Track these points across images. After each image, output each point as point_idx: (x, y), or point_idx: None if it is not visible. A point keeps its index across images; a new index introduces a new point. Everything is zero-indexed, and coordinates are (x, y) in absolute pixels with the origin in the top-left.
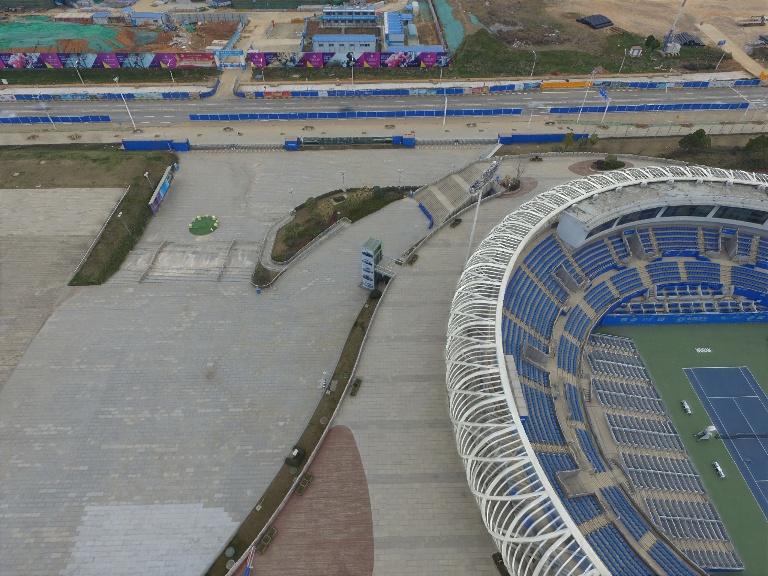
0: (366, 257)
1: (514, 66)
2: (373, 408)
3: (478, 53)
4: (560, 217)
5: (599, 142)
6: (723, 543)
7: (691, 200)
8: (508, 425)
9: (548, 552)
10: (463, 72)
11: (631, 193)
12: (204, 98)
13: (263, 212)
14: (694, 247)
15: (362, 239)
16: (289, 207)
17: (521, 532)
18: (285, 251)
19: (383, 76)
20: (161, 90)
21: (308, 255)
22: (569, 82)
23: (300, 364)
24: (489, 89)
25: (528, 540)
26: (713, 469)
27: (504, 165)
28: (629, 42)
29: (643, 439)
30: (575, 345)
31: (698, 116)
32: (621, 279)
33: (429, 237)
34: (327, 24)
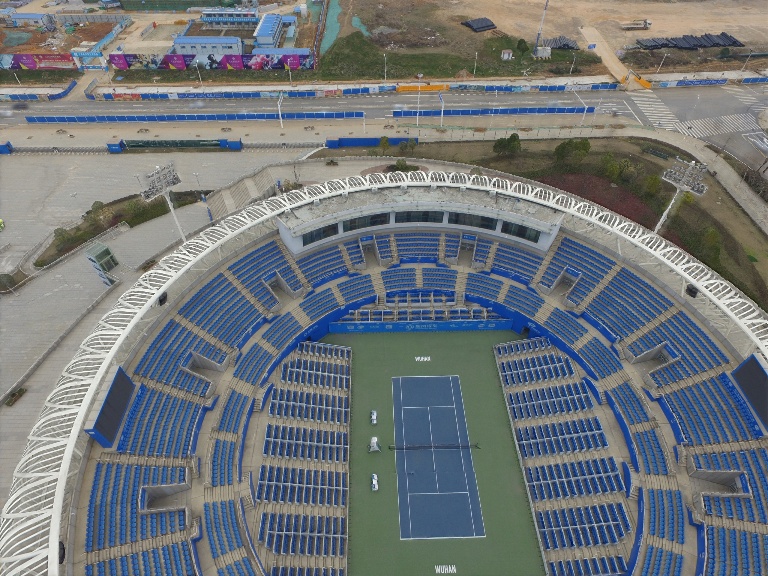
0: (93, 263)
1: (379, 69)
2: (23, 419)
3: (346, 56)
4: (276, 223)
5: (427, 146)
6: (341, 559)
7: (418, 206)
8: (62, 439)
9: (11, 574)
10: (326, 75)
11: (359, 198)
12: (54, 100)
13: (55, 216)
14: (434, 253)
15: (133, 244)
16: (84, 211)
17: (3, 552)
18: (52, 256)
19: (244, 78)
20: (15, 92)
21: (69, 260)
22: (425, 85)
23: (3, 372)
24: (343, 92)
25: (2, 561)
26: (370, 482)
27: (297, 169)
28: (506, 45)
29: (299, 451)
30: (270, 354)
31: (542, 120)
32: (350, 286)
33: (178, 242)
34: (208, 26)
